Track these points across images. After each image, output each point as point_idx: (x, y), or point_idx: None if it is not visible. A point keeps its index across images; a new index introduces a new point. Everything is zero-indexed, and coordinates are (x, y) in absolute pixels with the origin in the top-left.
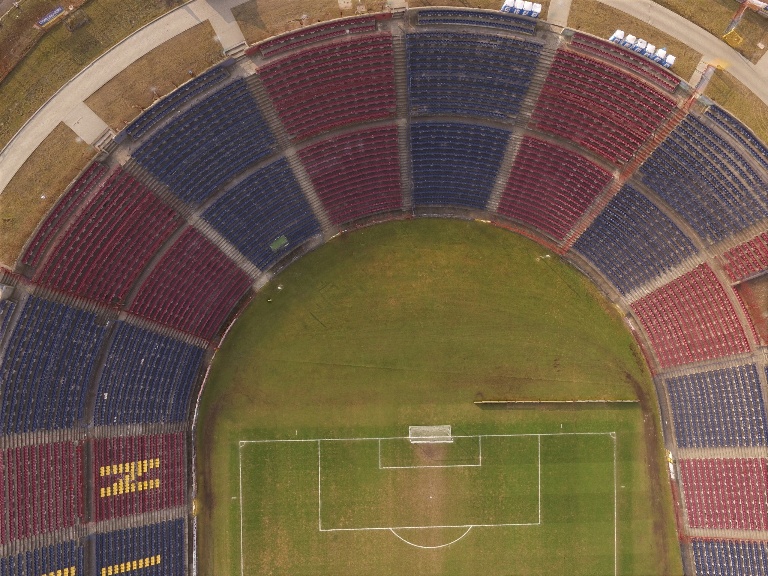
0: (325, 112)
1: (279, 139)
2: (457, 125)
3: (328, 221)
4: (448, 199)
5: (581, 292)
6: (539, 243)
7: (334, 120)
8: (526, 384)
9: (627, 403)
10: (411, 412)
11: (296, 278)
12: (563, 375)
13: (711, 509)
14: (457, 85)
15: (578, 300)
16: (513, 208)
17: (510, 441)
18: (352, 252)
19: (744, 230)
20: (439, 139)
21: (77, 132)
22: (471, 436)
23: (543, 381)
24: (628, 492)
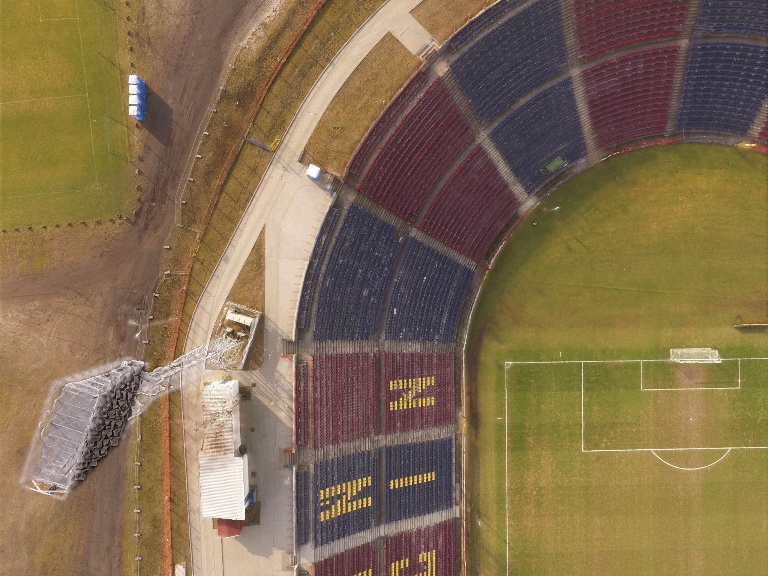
0: (618, 30)
1: (569, 58)
2: (738, 46)
3: (594, 145)
4: (711, 124)
5: None
6: None
7: (623, 39)
8: None
9: None
10: (672, 335)
11: (560, 202)
12: None
13: None
14: (749, 3)
15: None
16: None
17: None
18: (615, 176)
19: None
20: (717, 60)
21: (403, 42)
22: (730, 359)
23: None
24: None
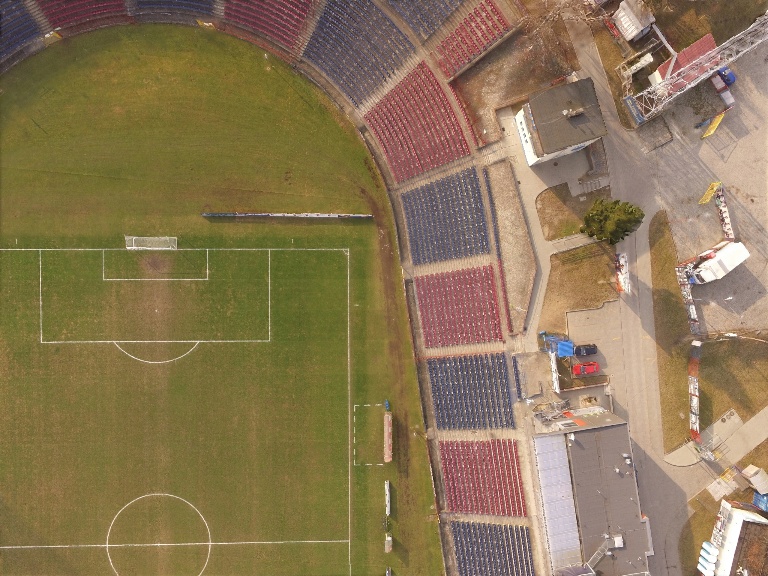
0: None
1: None
2: None
3: (48, 23)
4: (173, 3)
5: (314, 103)
6: (269, 52)
7: None
8: (256, 197)
9: (361, 219)
10: (136, 223)
11: (17, 83)
12: (295, 188)
13: (442, 326)
14: None
15: (311, 112)
16: (239, 12)
17: (239, 255)
18: (75, 57)
19: (450, 18)
20: None
21: None
22: (198, 249)
23: (273, 194)
24: (362, 311)
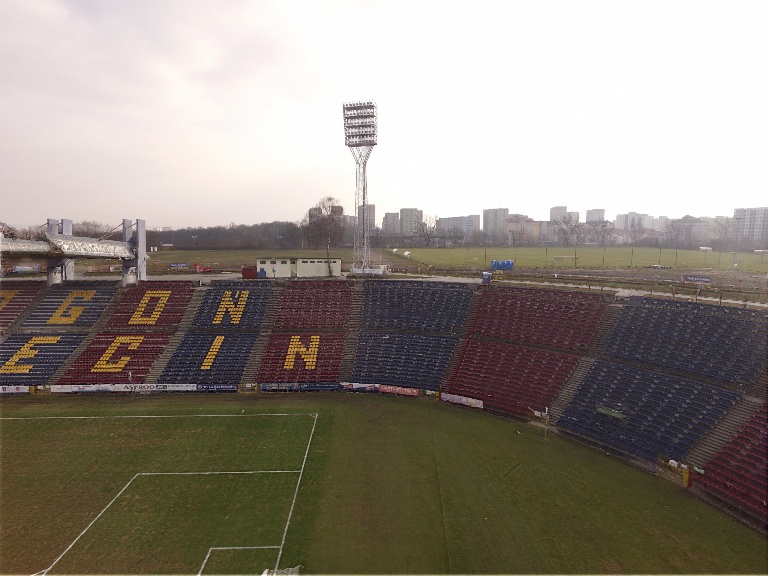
0: None
1: (760, 384)
2: None
3: None
4: None
5: None
6: None
7: None
8: None
9: None
10: None
11: (568, 451)
12: None
13: None
14: None
15: None
16: None
17: None
18: (668, 505)
19: None
20: None
21: None
22: None
23: None
24: None
